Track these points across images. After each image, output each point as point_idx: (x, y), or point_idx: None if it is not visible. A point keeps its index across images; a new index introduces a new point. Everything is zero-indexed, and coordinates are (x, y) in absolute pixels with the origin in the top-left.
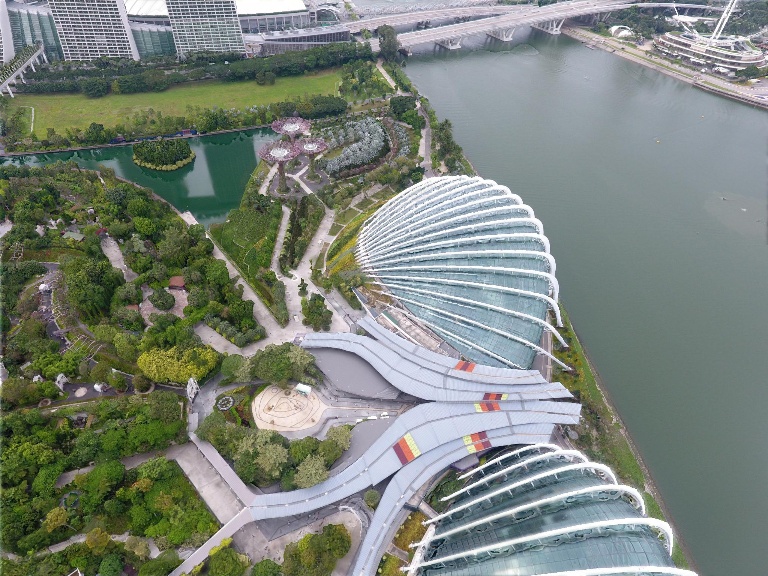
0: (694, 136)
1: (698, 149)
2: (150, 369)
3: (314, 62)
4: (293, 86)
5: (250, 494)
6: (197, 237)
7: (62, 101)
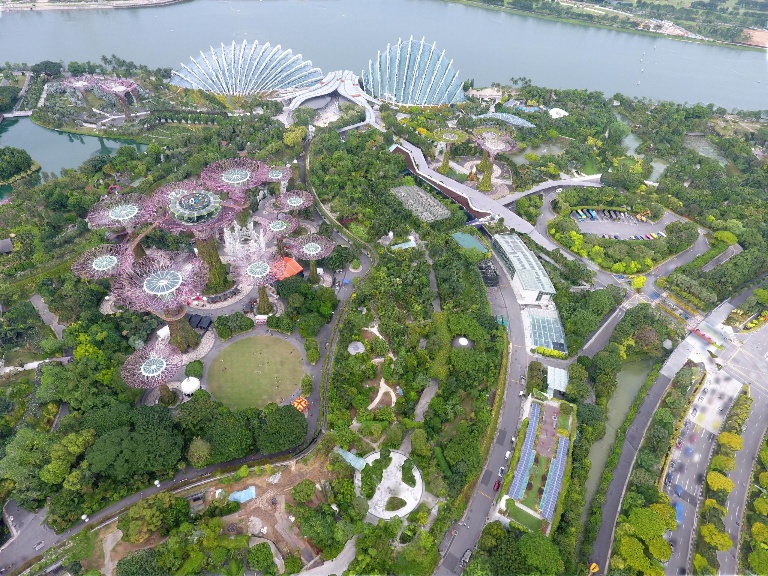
0: (174, 24)
1: (188, 27)
2: (297, 138)
3: None
4: None
5: None
6: None
7: None
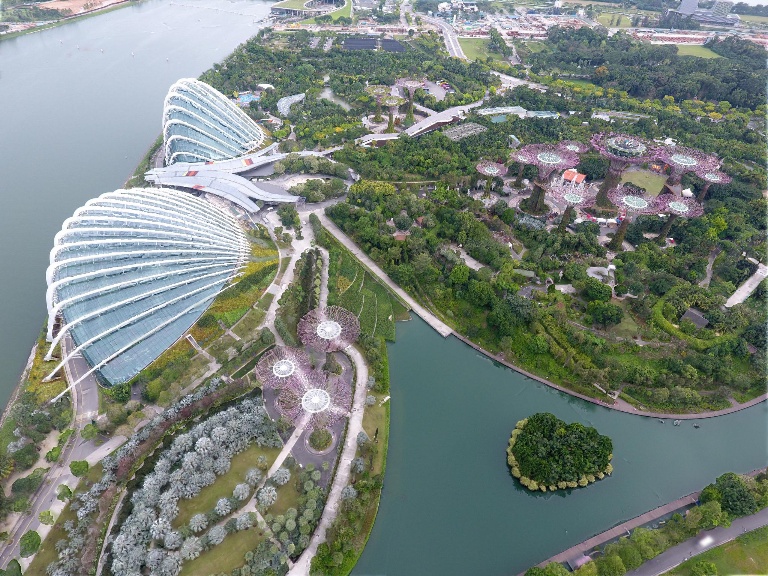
0: None
1: None
2: None
3: None
4: None
5: None
6: None
7: None
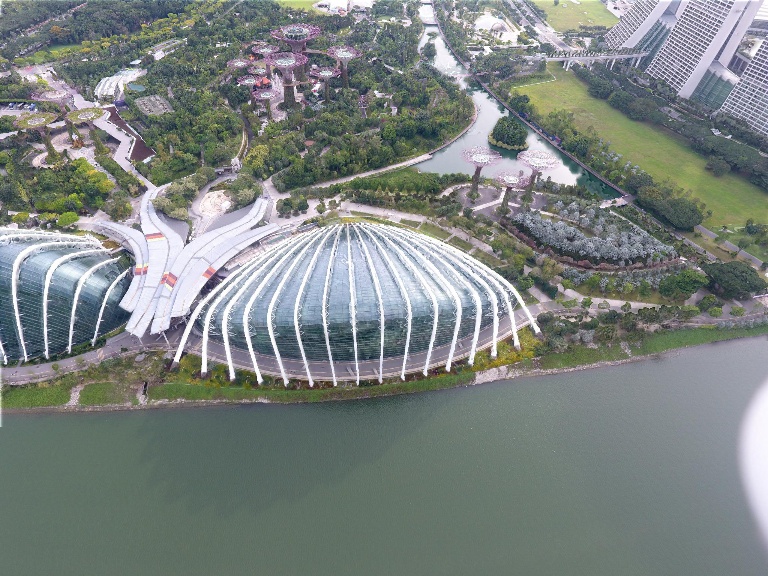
0: None
1: None
2: None
3: None
4: (728, 191)
5: (163, 188)
6: (381, 153)
7: (575, 86)
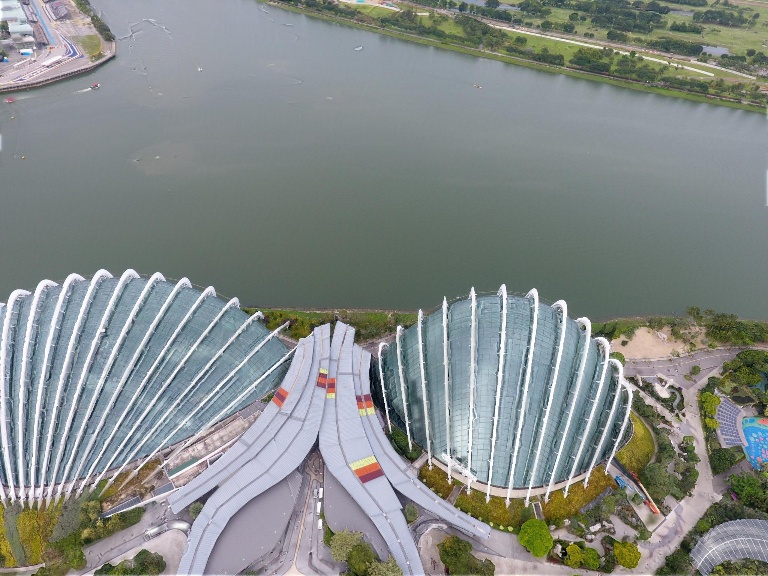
0: (36, 135)
1: (58, 142)
2: None
3: None
4: None
5: None
6: None
7: None
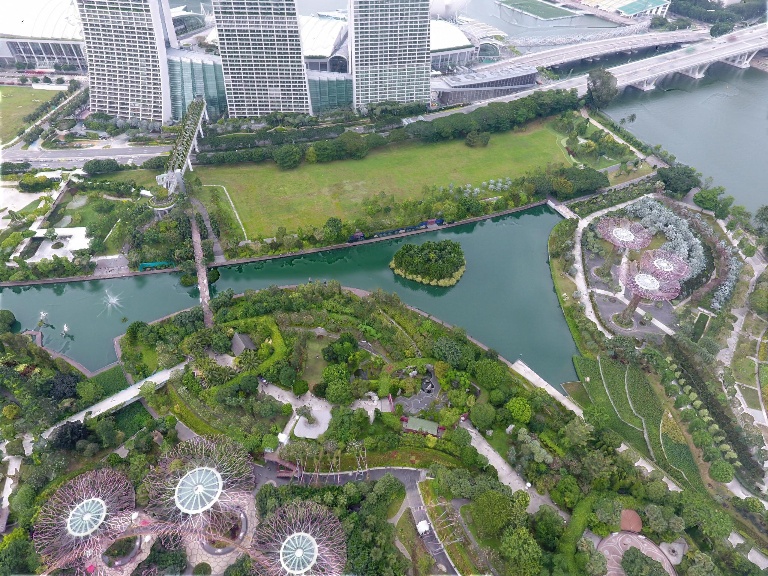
0: None
1: None
2: None
3: (525, 116)
4: (510, 148)
5: None
6: (599, 427)
7: (253, 175)
